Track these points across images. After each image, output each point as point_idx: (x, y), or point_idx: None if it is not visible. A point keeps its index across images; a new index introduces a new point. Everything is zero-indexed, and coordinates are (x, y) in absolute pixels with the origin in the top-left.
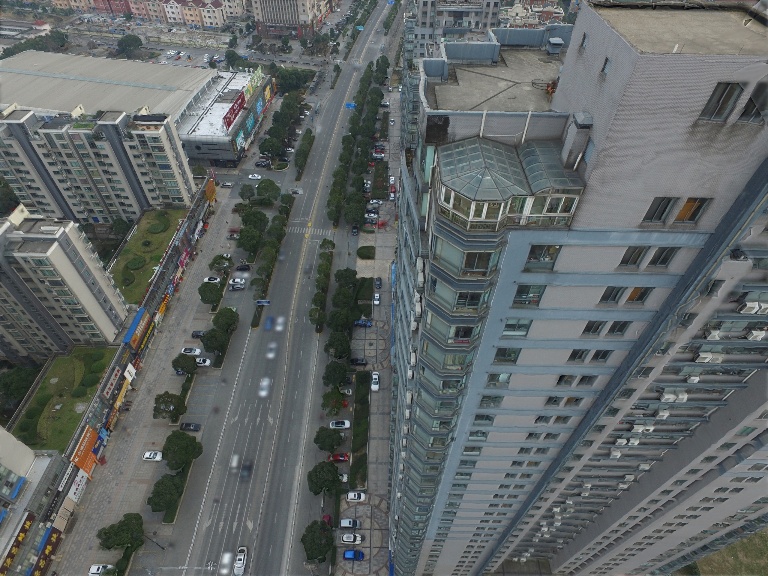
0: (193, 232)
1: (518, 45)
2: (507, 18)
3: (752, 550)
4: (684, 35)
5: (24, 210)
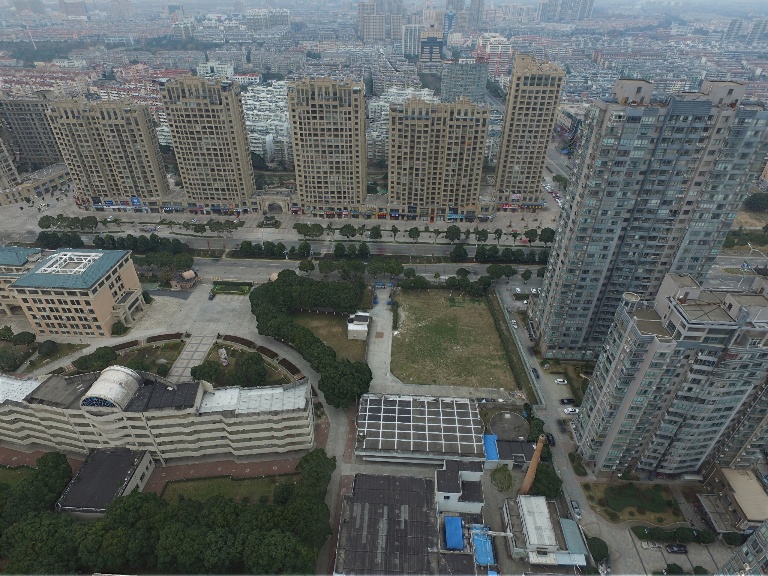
0: None
1: (762, 115)
2: None
3: (466, 340)
4: (727, 83)
5: None
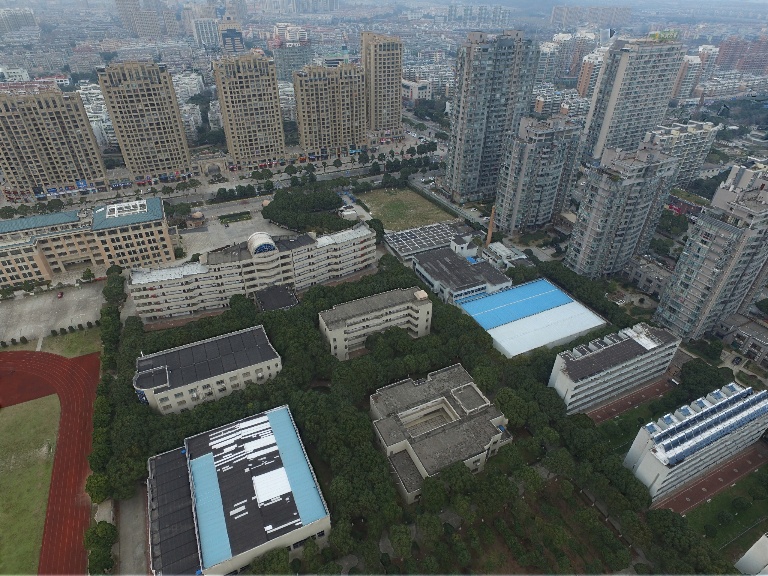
0: (695, 216)
1: None
2: (711, 209)
3: None
4: None
5: (678, 134)
